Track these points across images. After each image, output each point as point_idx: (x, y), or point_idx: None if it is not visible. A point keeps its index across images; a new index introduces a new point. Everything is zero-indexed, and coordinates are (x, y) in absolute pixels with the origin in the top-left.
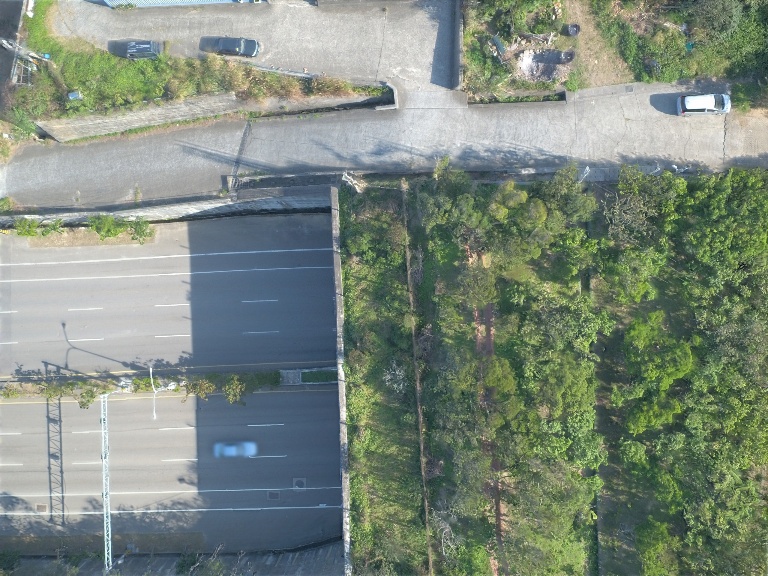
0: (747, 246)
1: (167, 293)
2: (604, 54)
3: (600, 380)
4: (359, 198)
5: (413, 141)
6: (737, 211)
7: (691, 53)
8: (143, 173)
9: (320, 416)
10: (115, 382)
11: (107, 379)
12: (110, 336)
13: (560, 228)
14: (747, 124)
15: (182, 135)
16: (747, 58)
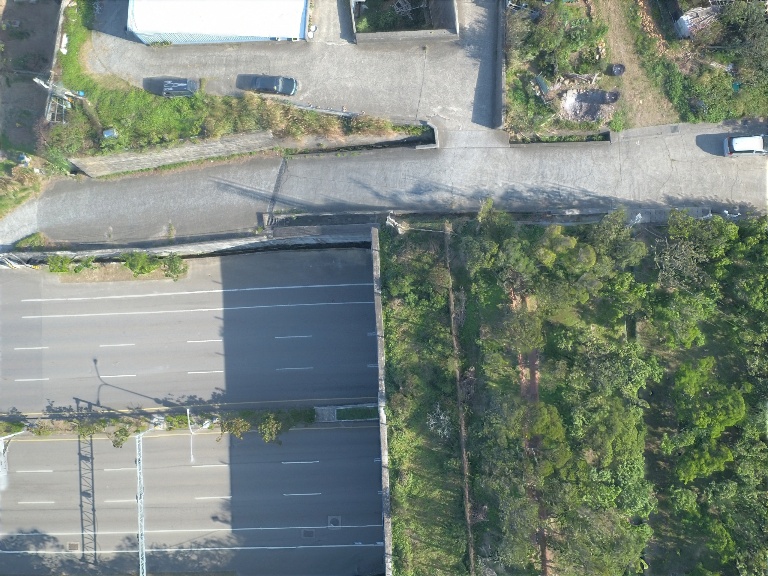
0: None
1: (200, 329)
2: (649, 94)
3: (647, 424)
4: (400, 239)
5: (454, 181)
6: None
7: (738, 94)
8: (177, 209)
9: (355, 453)
10: (147, 419)
11: (139, 416)
12: (142, 372)
13: (605, 270)
14: None
15: (216, 171)
16: None
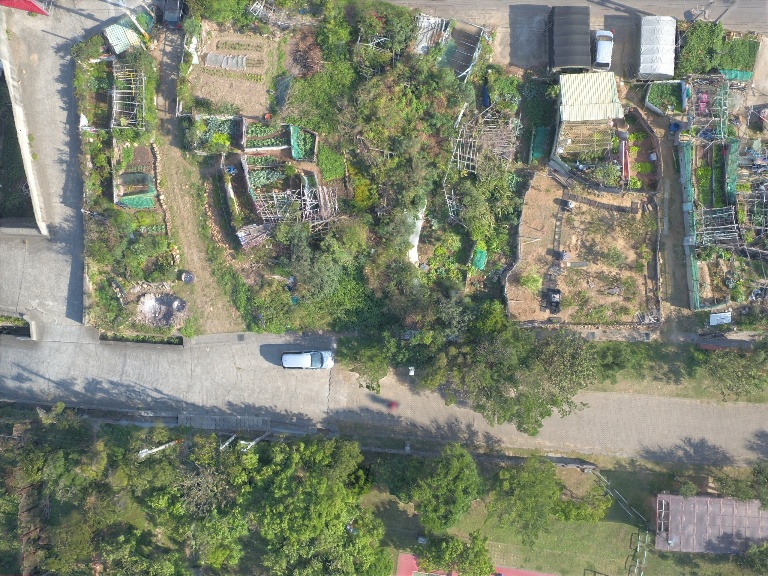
0: (301, 530)
1: None
2: (218, 302)
3: None
4: None
5: (50, 373)
6: (294, 493)
7: None
8: None
9: None
10: None
11: None
12: None
13: None
14: (350, 379)
15: None
16: (348, 315)
